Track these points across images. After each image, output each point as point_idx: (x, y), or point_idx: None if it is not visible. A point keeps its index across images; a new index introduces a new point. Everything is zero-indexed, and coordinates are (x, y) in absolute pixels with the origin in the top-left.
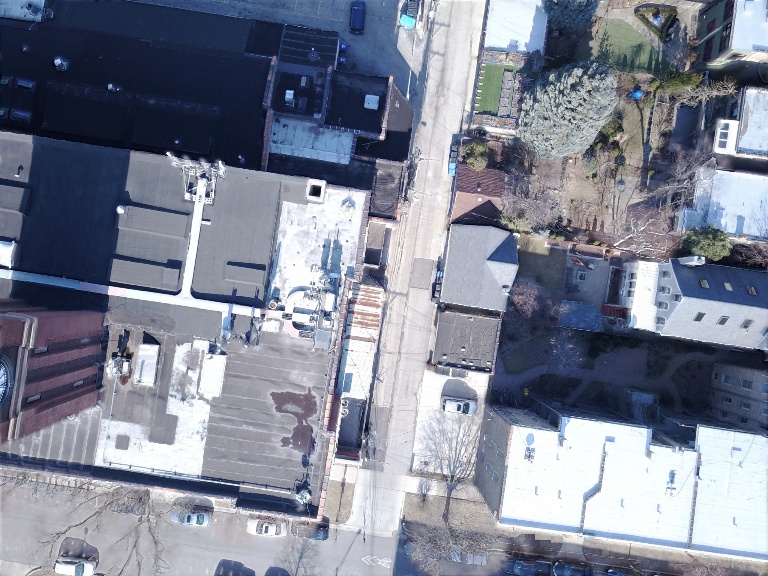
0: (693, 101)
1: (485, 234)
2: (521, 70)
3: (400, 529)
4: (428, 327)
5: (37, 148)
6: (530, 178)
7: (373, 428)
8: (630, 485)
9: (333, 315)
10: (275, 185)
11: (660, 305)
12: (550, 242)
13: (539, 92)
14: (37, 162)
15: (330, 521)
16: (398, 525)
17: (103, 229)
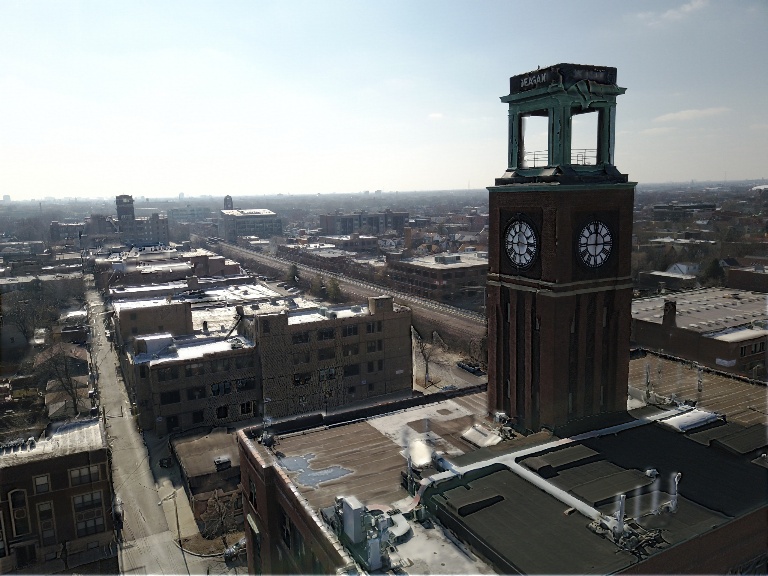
0: None
1: None
2: None
3: None
4: None
5: None
6: None
7: None
8: None
9: None
10: None
11: None
12: None
13: None
14: None
15: None
16: None
17: (644, 466)
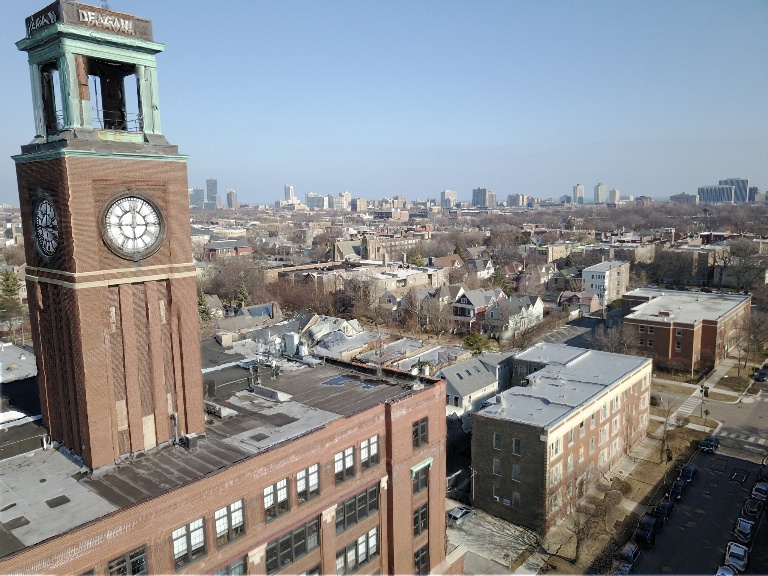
0: None
1: None
2: None
3: None
4: None
5: None
6: None
7: None
8: (550, 393)
9: None
10: None
11: (447, 402)
12: None
13: None
14: None
15: None
16: None
17: None
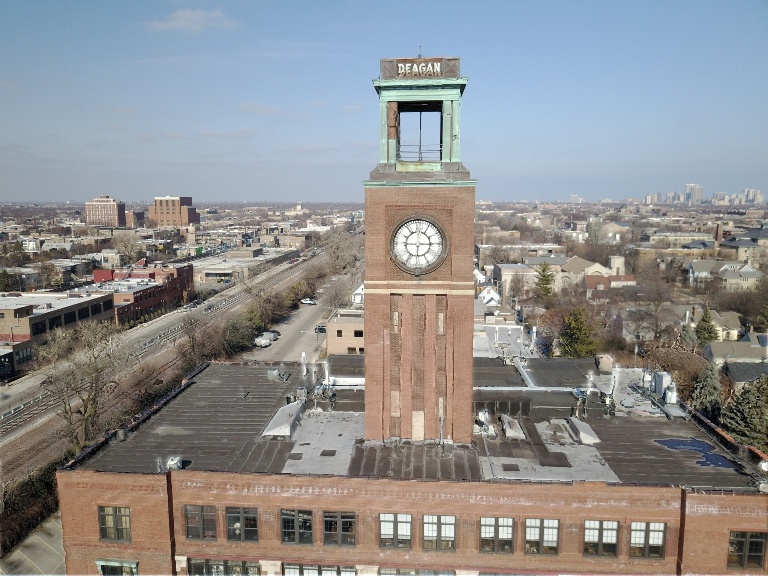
0: None
1: None
2: None
3: None
4: None
5: None
6: None
7: None
8: None
9: None
10: None
11: None
12: None
13: None
14: None
15: None
16: None
17: None
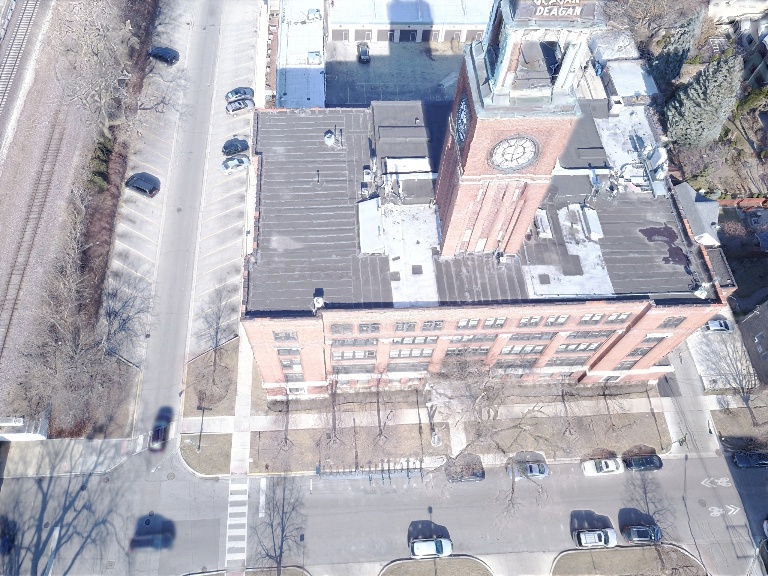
0: (767, 105)
1: (684, 188)
2: (650, 104)
3: (721, 447)
4: None
5: (424, 108)
6: (683, 170)
7: None
8: None
9: (666, 164)
10: (587, 106)
11: None
12: (720, 204)
13: (682, 94)
14: (427, 115)
15: (656, 451)
16: (718, 443)
17: None
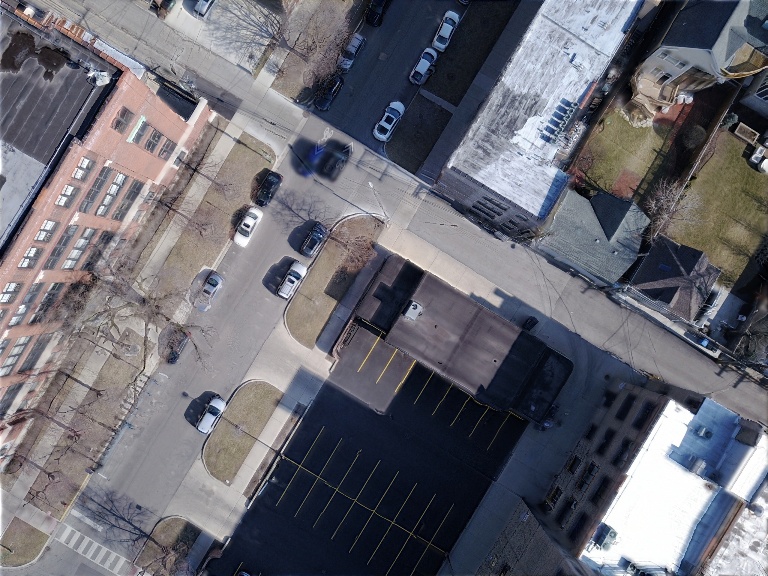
0: None
1: None
2: None
3: (303, 108)
4: (126, 3)
5: None
6: None
7: (198, 92)
8: None
9: None
10: None
11: None
12: None
13: None
14: None
15: (268, 168)
16: (298, 108)
17: None
